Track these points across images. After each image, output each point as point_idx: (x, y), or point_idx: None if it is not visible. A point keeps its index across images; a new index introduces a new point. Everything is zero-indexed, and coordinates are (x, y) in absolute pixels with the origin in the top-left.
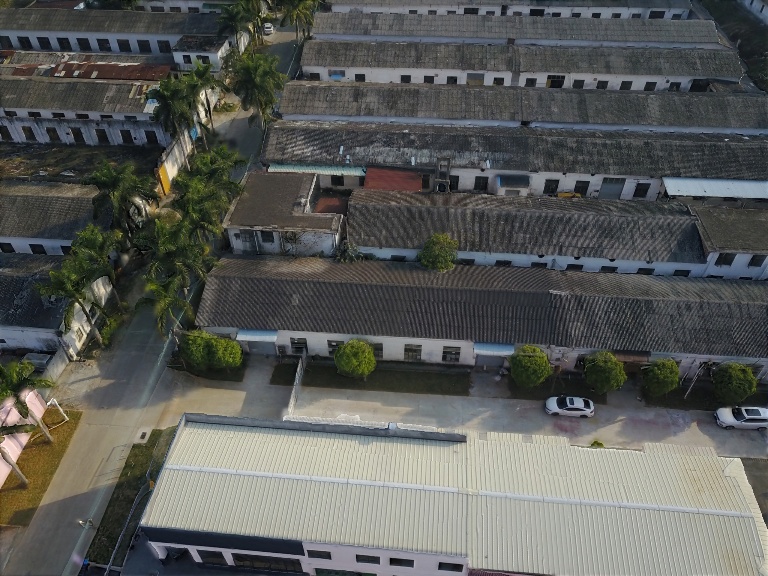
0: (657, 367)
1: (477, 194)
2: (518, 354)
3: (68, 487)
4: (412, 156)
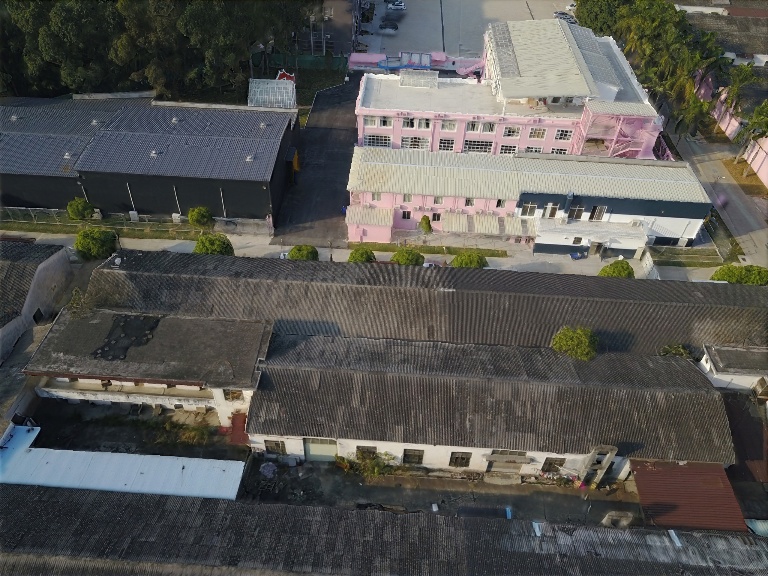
0: (368, 254)
1: (545, 449)
2: (483, 255)
3: (763, 235)
4: (682, 547)
